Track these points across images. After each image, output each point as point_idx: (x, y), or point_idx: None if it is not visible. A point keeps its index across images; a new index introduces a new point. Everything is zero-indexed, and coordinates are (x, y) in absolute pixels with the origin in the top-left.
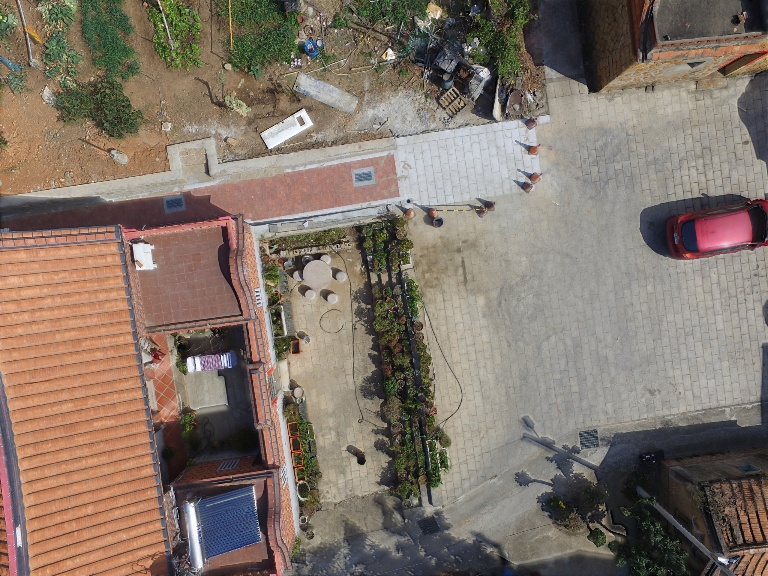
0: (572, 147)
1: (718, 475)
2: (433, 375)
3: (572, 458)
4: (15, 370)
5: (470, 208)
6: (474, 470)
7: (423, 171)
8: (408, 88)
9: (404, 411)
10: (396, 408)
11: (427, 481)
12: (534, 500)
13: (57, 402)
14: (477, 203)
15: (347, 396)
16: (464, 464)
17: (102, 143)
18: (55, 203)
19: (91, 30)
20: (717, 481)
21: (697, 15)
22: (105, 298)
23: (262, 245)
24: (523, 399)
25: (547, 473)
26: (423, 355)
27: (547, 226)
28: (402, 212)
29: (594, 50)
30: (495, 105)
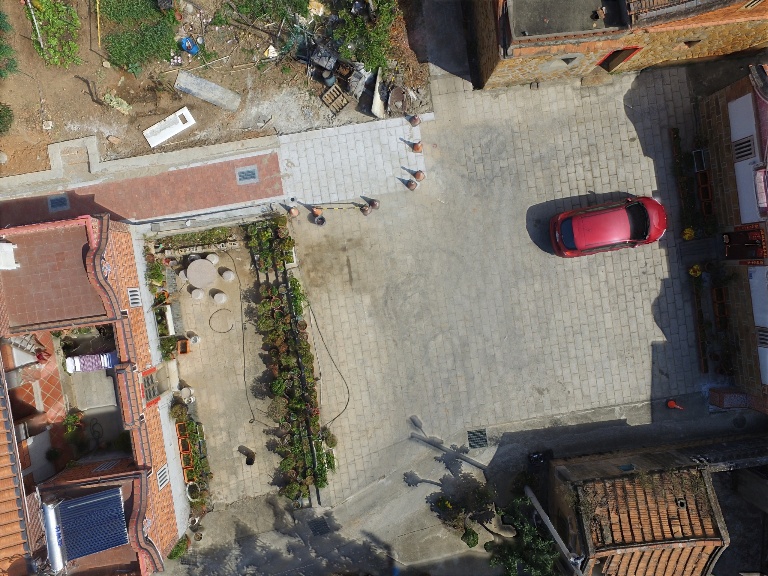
0: (457, 144)
1: (596, 474)
2: (319, 375)
3: (461, 458)
4: None
5: (354, 206)
6: (362, 470)
7: (307, 169)
8: (292, 86)
9: (291, 411)
10: (279, 408)
11: (314, 481)
12: (423, 500)
13: None
14: (361, 201)
15: (238, 396)
16: (352, 464)
17: None
18: None
19: None
20: (591, 480)
21: (556, 10)
22: None
23: (147, 244)
24: (410, 398)
25: (436, 473)
26: (305, 354)
27: (432, 224)
28: (286, 210)
29: (477, 47)
30: (375, 102)
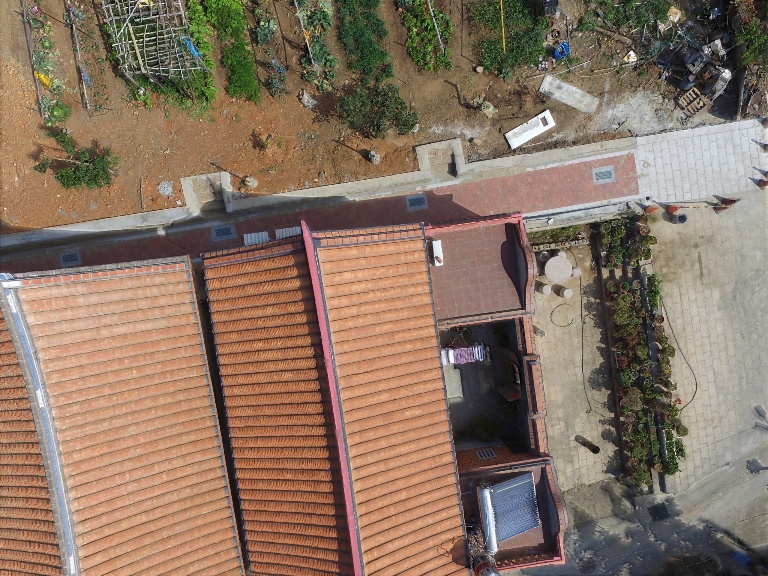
0: None
1: None
2: (669, 366)
3: None
4: (345, 362)
5: (707, 205)
6: (707, 458)
7: (662, 169)
8: (647, 89)
9: None
10: None
11: (663, 469)
12: (765, 487)
13: (376, 392)
14: (714, 200)
15: (576, 388)
16: (697, 452)
17: (355, 144)
18: (303, 202)
19: (350, 35)
20: None
21: None
22: (413, 293)
23: None
24: (755, 389)
25: None
26: (668, 347)
27: None
28: (642, 209)
29: None
30: None
